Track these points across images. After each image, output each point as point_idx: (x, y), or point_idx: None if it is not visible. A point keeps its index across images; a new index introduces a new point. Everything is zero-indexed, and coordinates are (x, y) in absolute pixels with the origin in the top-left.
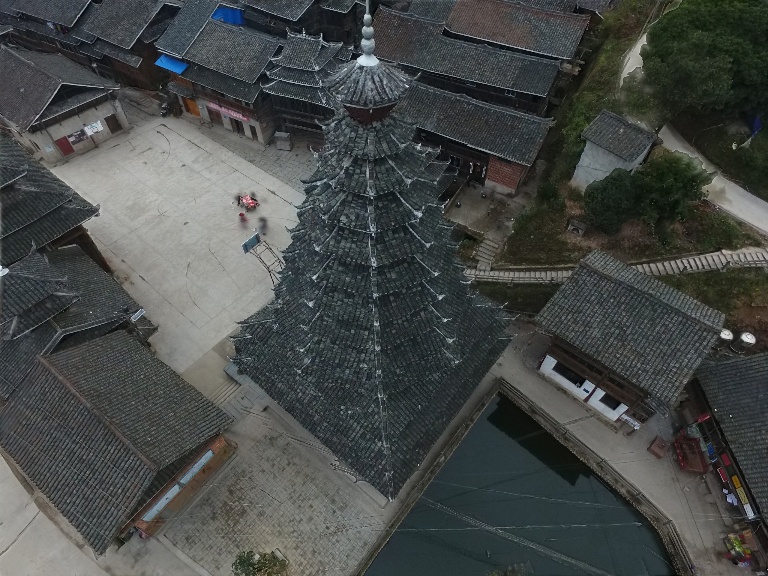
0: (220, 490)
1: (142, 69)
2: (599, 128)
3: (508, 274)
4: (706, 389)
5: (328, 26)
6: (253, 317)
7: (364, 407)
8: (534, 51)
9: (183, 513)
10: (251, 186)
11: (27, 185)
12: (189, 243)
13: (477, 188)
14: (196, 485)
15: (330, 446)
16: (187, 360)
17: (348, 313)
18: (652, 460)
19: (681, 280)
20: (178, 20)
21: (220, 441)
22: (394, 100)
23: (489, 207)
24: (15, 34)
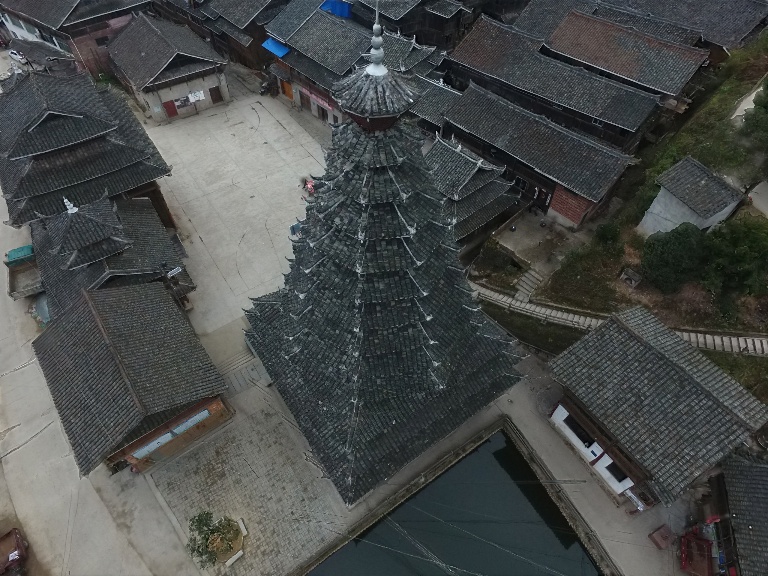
0: (209, 449)
1: (251, 48)
2: (678, 175)
3: (545, 310)
4: (730, 489)
5: (429, 29)
6: (266, 296)
7: (339, 407)
8: (636, 81)
9: (172, 460)
10: (320, 173)
11: (117, 138)
12: (250, 215)
13: (538, 215)
14: (189, 438)
15: (308, 436)
16: (217, 322)
17: (333, 313)
18: (651, 548)
19: (738, 361)
20: (290, 7)
21: (218, 404)
22: (393, 113)
23: (545, 237)
24: (159, 4)
